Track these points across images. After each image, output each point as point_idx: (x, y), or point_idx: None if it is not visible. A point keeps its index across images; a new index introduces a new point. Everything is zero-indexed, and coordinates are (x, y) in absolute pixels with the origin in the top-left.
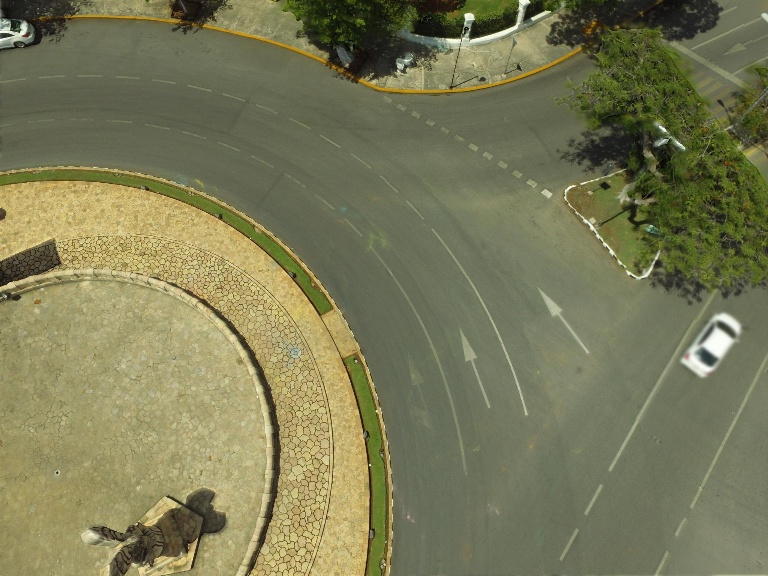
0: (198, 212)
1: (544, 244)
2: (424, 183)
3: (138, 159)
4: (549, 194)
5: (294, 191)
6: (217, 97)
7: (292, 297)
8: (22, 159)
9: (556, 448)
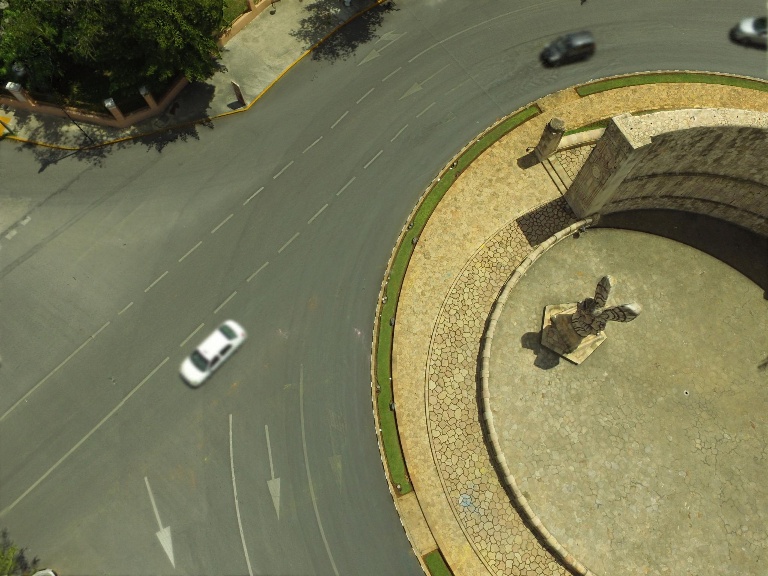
0: None
1: None
2: None
3: None
4: None
5: None
6: None
7: None
8: None
9: (212, 381)
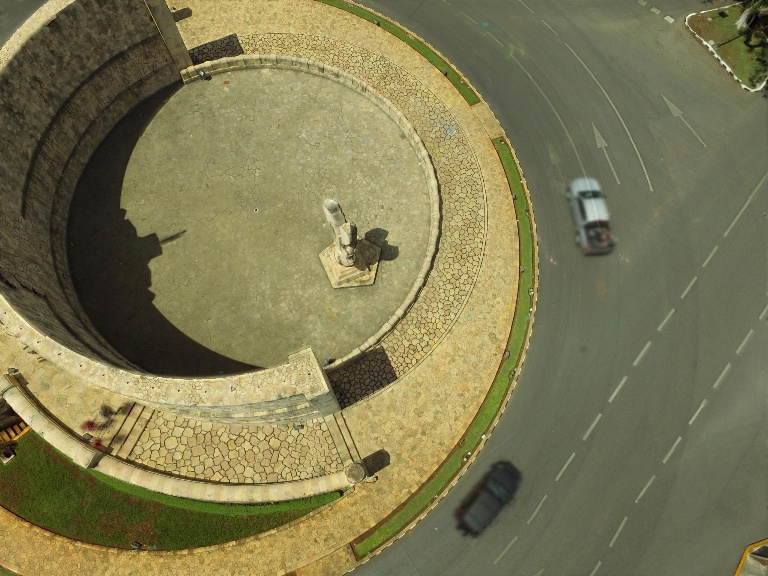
0: (359, 19)
1: (667, 60)
2: (557, 6)
3: None
4: (671, 20)
5: (441, 8)
6: None
7: (445, 89)
8: None
9: (678, 217)
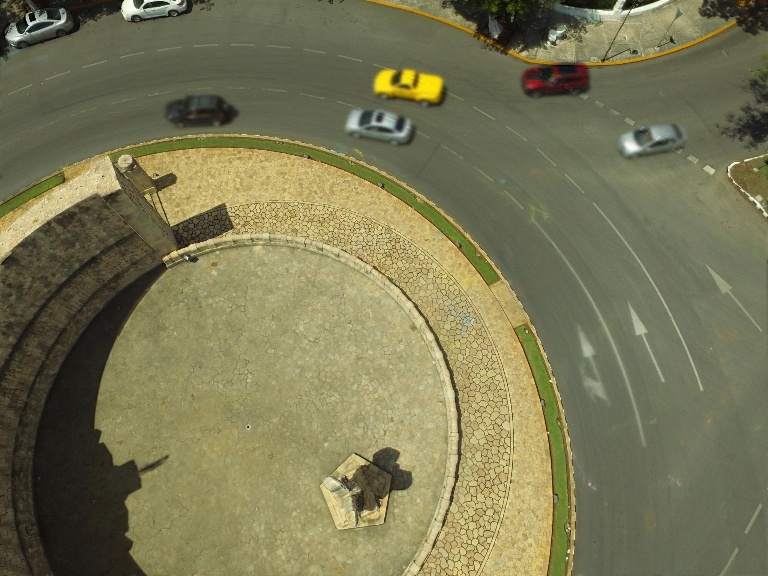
0: (361, 181)
1: (710, 221)
2: (582, 157)
3: (296, 128)
4: (712, 170)
5: (452, 162)
6: (368, 67)
7: (460, 267)
8: (185, 126)
9: (734, 424)
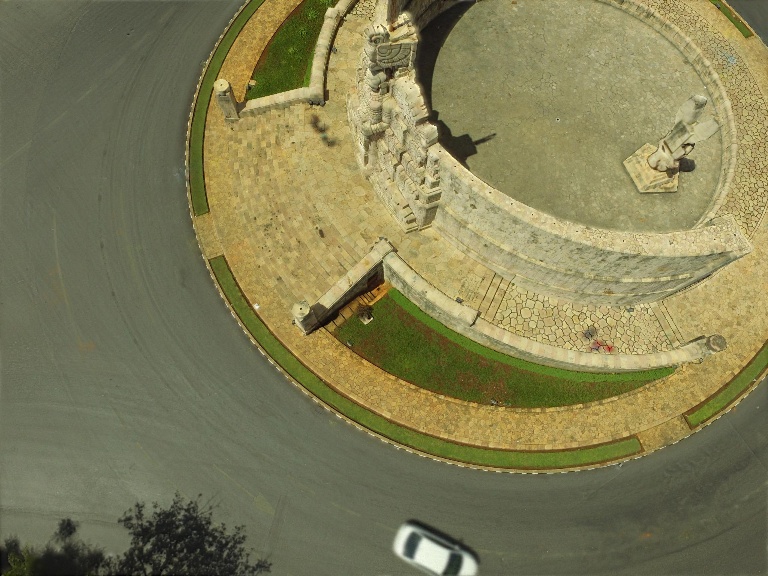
0: None
1: None
2: None
3: None
4: None
5: None
6: None
7: (721, 21)
8: None
9: None
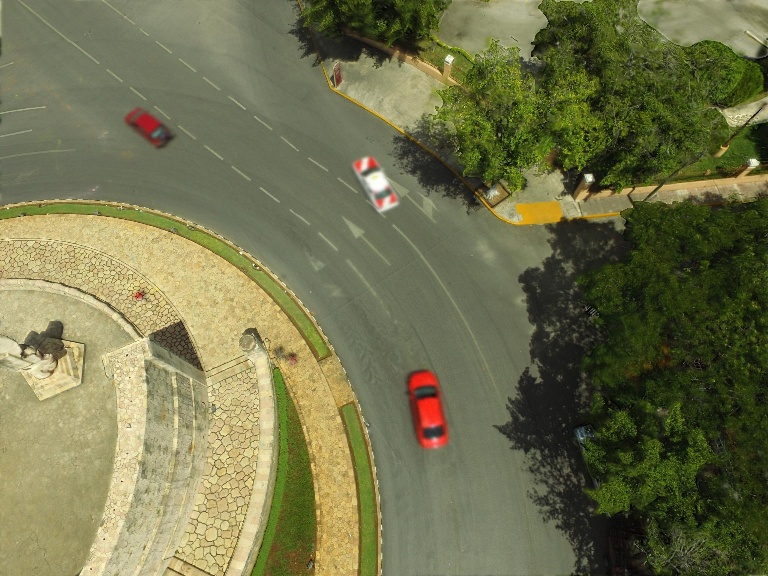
0: None
1: None
2: None
3: None
4: None
5: None
6: None
7: None
8: None
9: (74, 92)
